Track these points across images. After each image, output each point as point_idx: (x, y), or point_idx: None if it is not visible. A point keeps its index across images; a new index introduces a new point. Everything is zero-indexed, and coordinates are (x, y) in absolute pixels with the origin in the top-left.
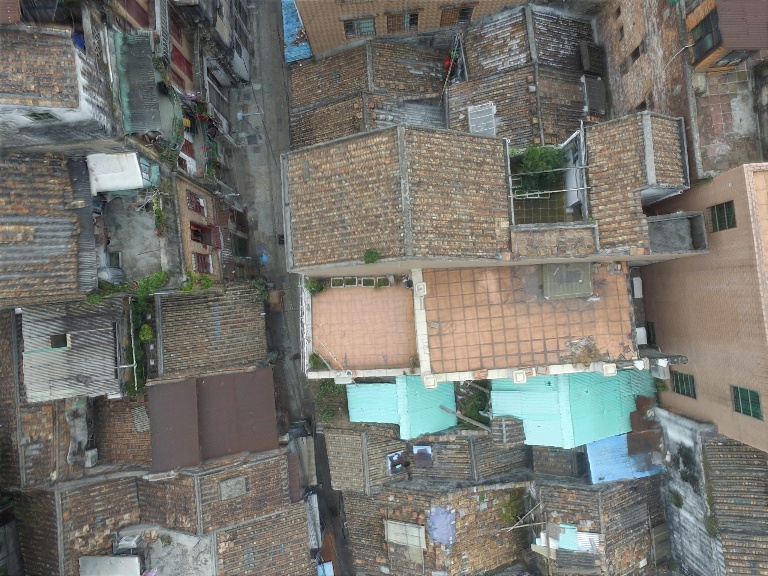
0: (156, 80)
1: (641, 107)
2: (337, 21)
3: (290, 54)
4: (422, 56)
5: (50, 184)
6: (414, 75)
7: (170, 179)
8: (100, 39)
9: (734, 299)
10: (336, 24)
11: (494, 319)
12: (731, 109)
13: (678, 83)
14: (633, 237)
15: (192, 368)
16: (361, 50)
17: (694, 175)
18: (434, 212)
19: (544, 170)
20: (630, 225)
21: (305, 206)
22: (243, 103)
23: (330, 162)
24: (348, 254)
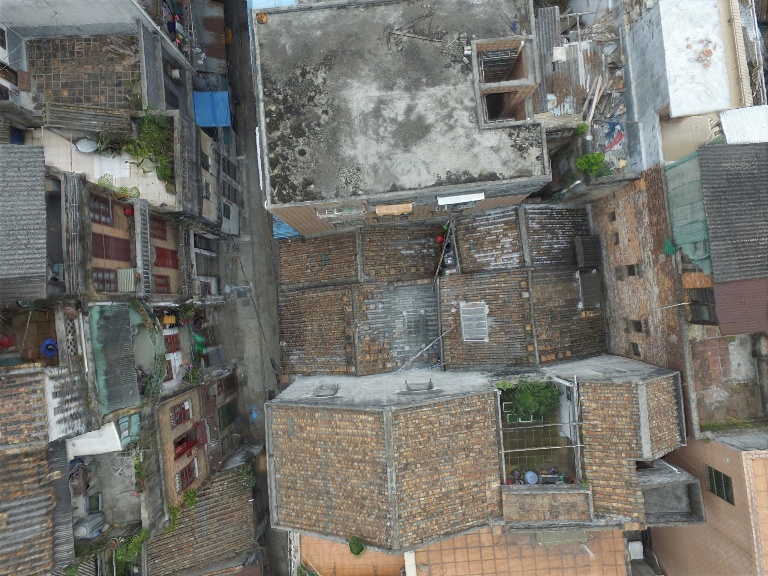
0: (137, 321)
1: (637, 323)
2: (325, 223)
3: (279, 230)
4: (413, 234)
5: (24, 463)
6: (405, 255)
7: (152, 415)
8: (74, 328)
9: (732, 572)
10: (324, 224)
11: (485, 562)
12: (729, 353)
13: (674, 333)
14: (628, 507)
15: (177, 571)
16: (351, 236)
17: (691, 433)
18: (422, 492)
19: (536, 425)
20: (625, 494)
21: (290, 465)
22: (232, 255)
23: (315, 426)
24: (333, 528)
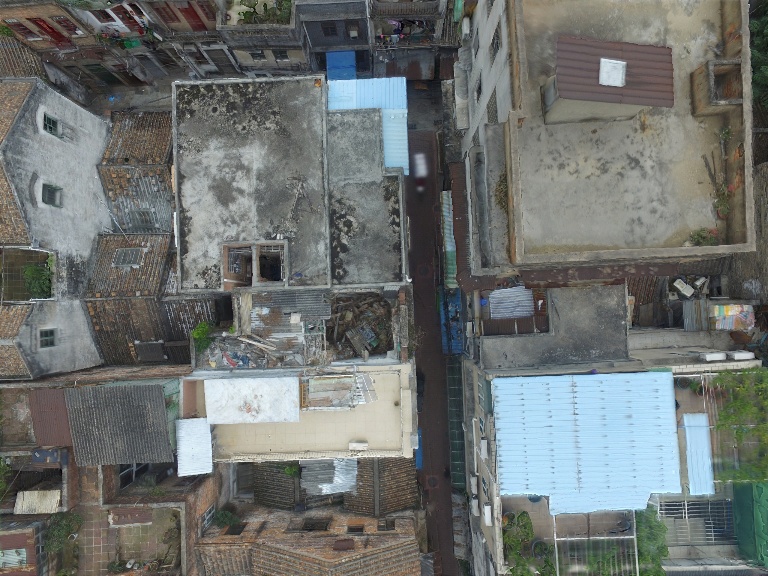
0: None
1: None
2: None
3: None
4: None
5: None
6: None
7: None
8: None
9: None
10: None
11: None
12: None
13: None
14: None
15: None
16: None
17: None
18: None
19: None
20: None
21: None
22: None
23: (8, 109)
24: None
